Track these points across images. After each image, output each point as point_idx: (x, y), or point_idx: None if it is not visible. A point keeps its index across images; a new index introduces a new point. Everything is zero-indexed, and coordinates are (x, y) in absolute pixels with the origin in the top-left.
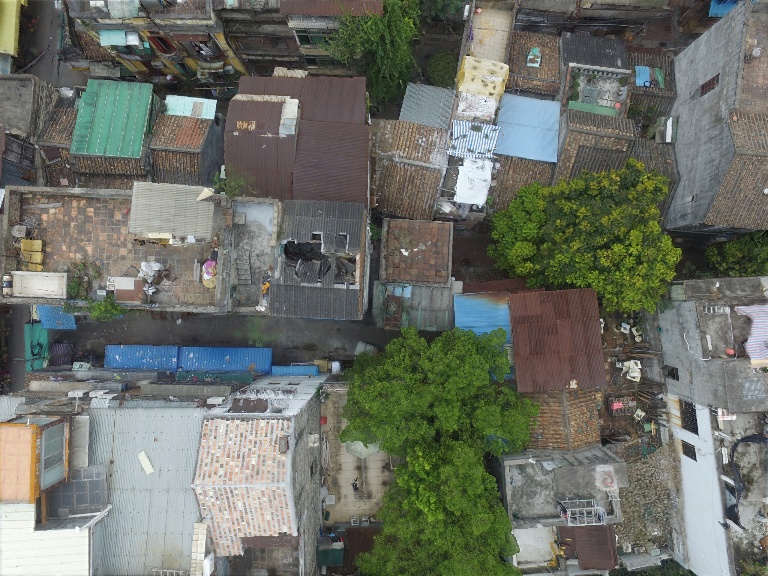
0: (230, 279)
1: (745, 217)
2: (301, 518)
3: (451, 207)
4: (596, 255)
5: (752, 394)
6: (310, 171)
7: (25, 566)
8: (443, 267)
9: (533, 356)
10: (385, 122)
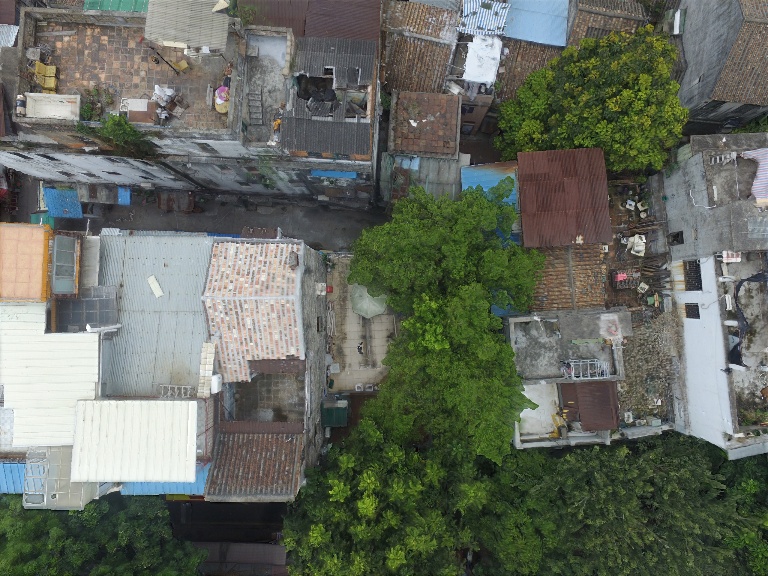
0: (242, 110)
1: (751, 92)
2: (308, 354)
3: (459, 89)
4: (605, 104)
5: (757, 232)
6: (322, 19)
7: (35, 367)
8: (451, 138)
9: (540, 212)
10: (395, 2)
